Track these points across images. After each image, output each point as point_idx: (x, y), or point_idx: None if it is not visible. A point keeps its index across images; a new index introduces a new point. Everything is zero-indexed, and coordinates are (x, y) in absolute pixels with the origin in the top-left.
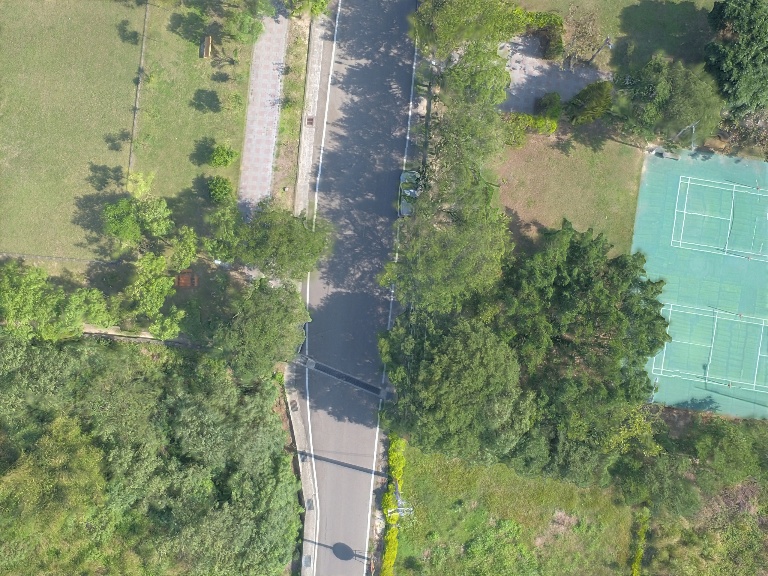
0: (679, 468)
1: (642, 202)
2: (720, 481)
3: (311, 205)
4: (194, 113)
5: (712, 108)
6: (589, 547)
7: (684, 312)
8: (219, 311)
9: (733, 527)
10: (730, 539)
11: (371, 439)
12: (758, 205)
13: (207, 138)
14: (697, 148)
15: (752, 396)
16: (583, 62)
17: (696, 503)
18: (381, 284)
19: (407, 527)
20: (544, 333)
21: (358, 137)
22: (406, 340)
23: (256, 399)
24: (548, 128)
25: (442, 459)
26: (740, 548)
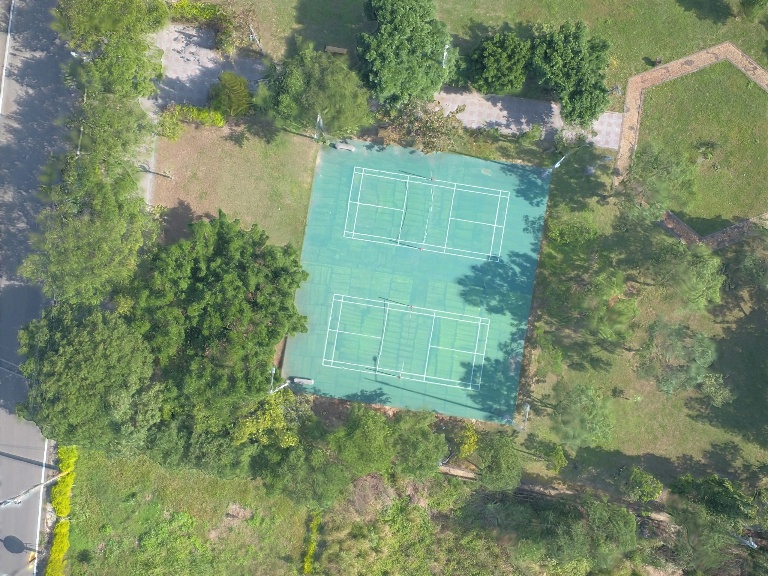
0: (311, 459)
1: (315, 193)
2: (346, 472)
3: None
4: None
5: (342, 97)
6: (263, 539)
7: (355, 303)
8: None
9: (404, 519)
10: (400, 531)
11: None
12: (431, 196)
13: None
14: (372, 139)
15: (422, 387)
16: (257, 53)
17: (324, 494)
18: (25, 276)
19: (80, 520)
20: (174, 324)
21: (32, 129)
22: (40, 331)
23: None
24: (211, 119)
25: None
26: (412, 540)
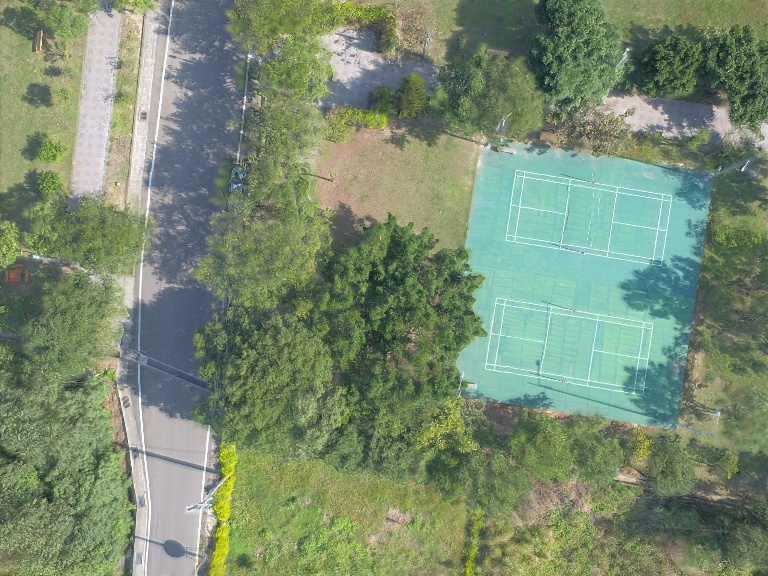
0: (493, 464)
1: (477, 196)
2: (531, 477)
3: (144, 200)
4: (27, 108)
5: (525, 101)
6: (423, 544)
7: (518, 307)
8: (51, 307)
9: (567, 524)
10: (564, 536)
11: (203, 435)
12: (593, 199)
13: (39, 133)
14: (533, 142)
15: (586, 392)
16: (418, 55)
17: (508, 499)
18: (199, 279)
19: (240, 524)
20: (356, 328)
21: (192, 131)
22: (219, 335)
23: (78, 395)
24: (377, 122)
25: (276, 456)
26: (575, 545)
